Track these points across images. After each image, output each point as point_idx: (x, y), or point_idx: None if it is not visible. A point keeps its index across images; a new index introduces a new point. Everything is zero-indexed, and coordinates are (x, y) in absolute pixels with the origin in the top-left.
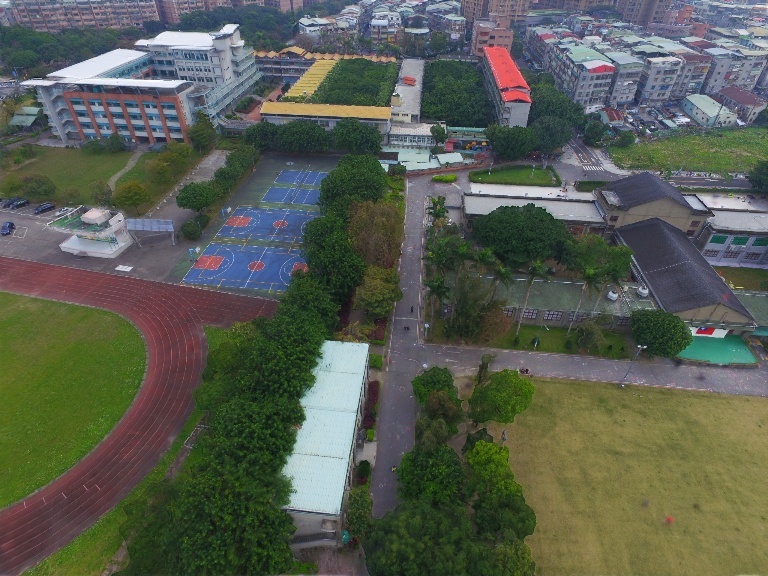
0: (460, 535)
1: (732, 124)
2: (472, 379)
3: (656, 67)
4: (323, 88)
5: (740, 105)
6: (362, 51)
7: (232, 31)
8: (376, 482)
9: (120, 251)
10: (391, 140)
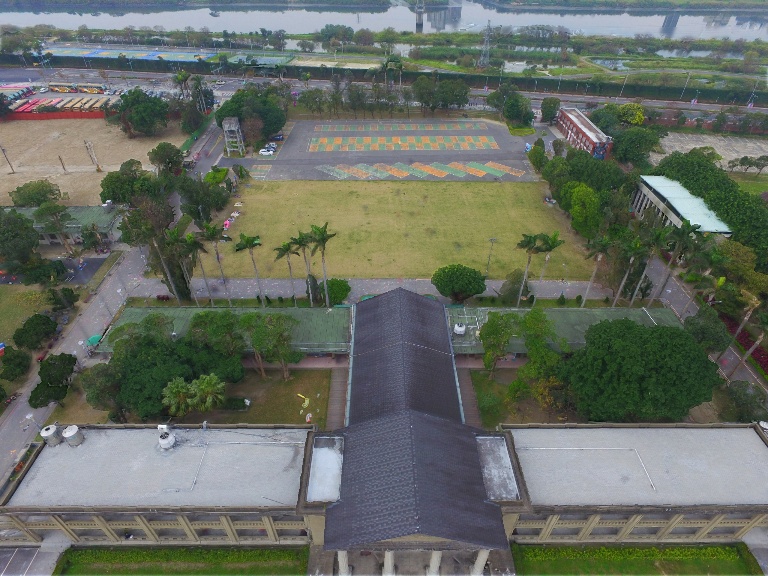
0: (587, 168)
1: None
2: None
3: None
4: None
5: None
6: None
7: None
8: (630, 227)
9: None
10: None
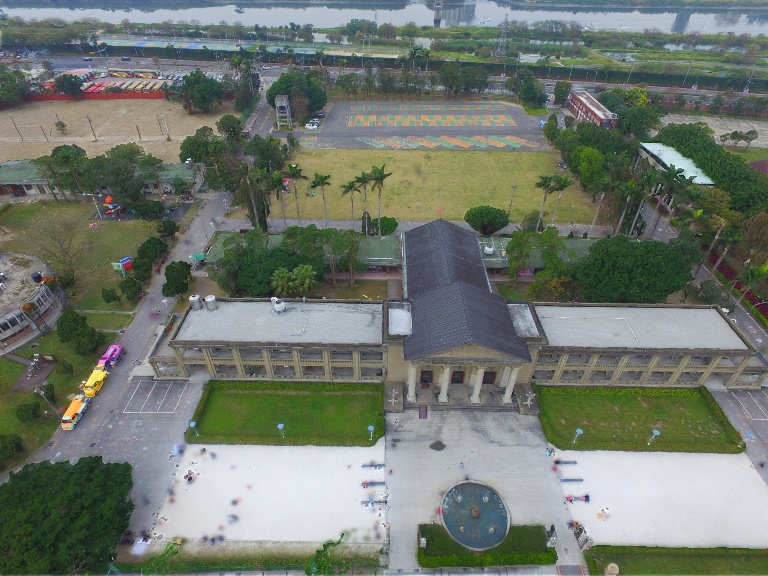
0: (594, 136)
1: None
2: None
3: None
4: None
5: None
6: None
7: None
8: None
9: None
10: None
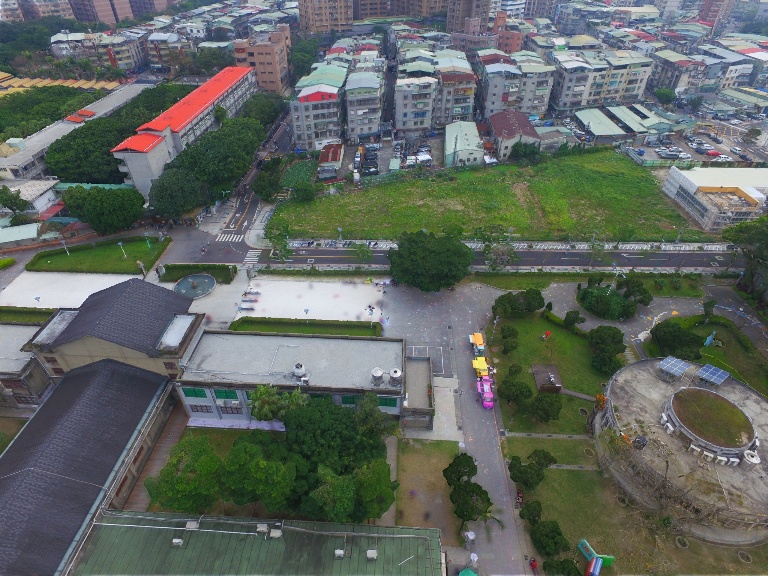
0: None
1: (477, 162)
2: None
3: (401, 91)
4: None
5: (493, 137)
6: (147, 70)
7: None
8: None
9: None
10: None
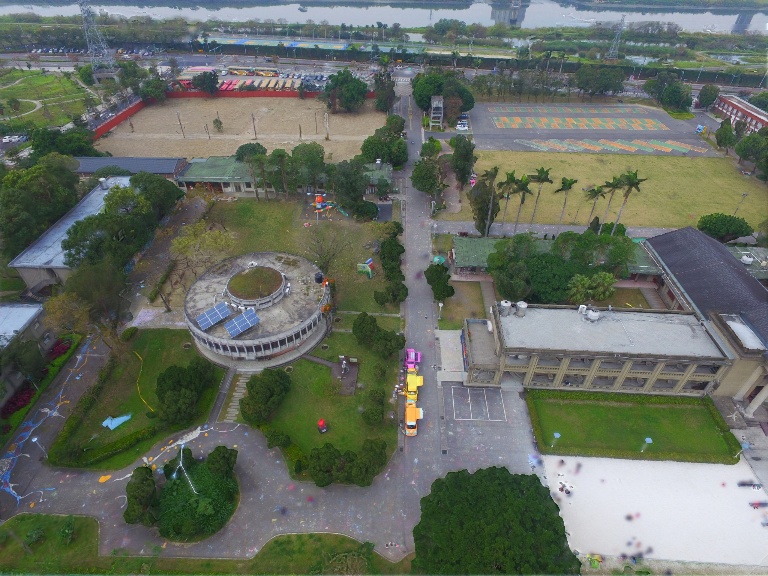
0: None
1: None
2: None
3: None
4: None
5: None
6: None
7: None
8: None
9: None
10: None
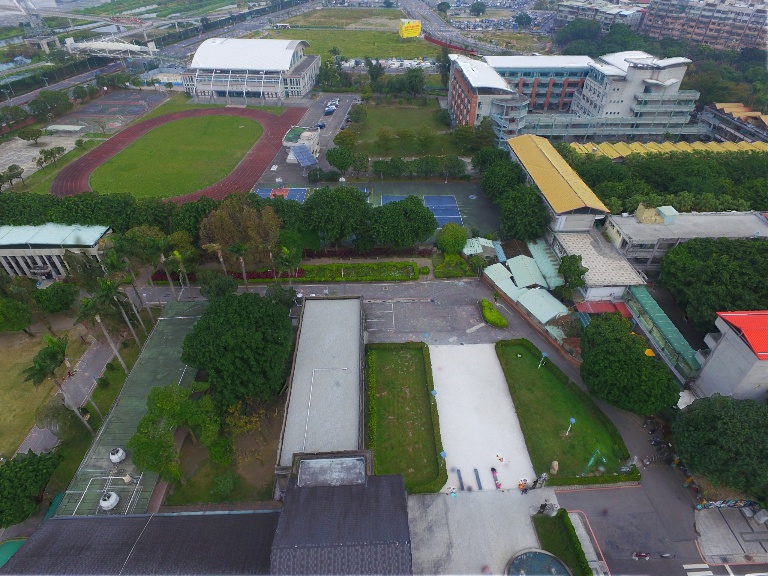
0: None
1: None
2: (83, 336)
3: None
4: (631, 158)
5: None
6: None
7: (665, 64)
8: None
9: (294, 161)
10: (556, 243)
